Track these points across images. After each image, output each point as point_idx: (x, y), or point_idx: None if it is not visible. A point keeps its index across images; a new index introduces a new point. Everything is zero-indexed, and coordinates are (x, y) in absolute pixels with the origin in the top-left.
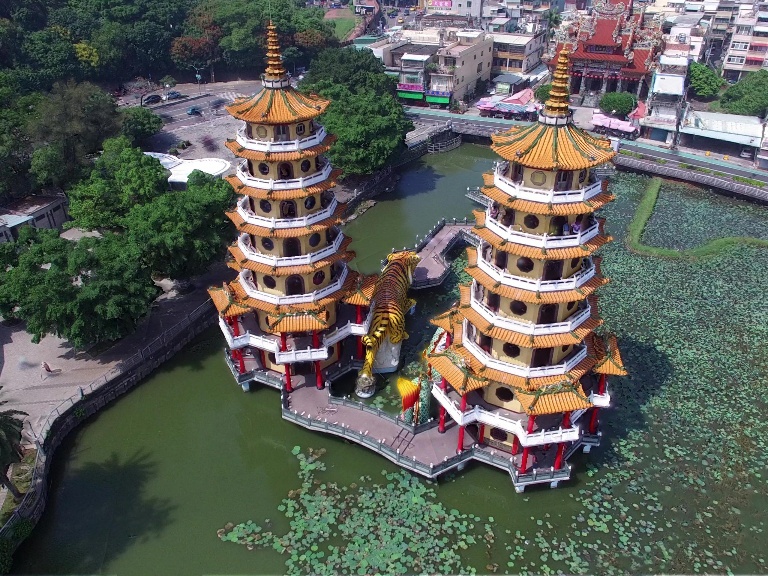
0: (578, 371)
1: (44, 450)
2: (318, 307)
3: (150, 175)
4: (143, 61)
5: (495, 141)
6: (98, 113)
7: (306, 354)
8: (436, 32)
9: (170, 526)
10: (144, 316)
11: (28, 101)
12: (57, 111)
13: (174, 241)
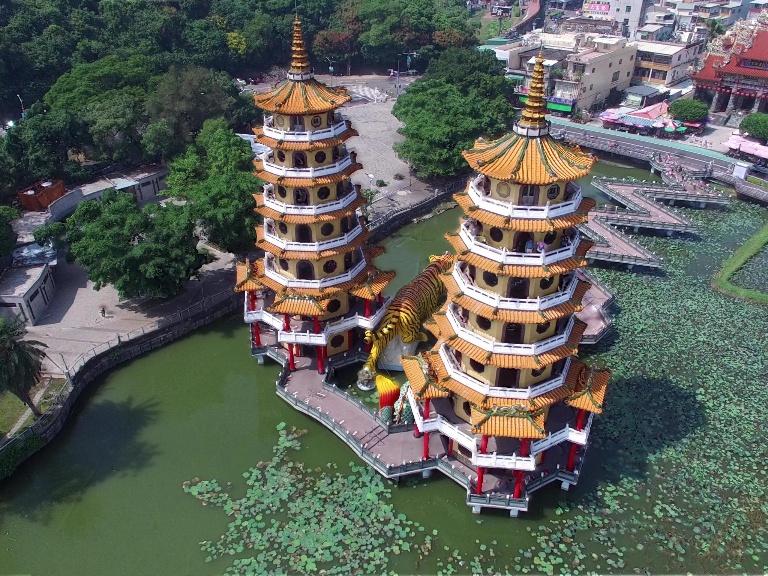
0: (545, 399)
1: (74, 382)
2: (321, 294)
3: (235, 155)
4: (287, 51)
5: (474, 148)
6: (206, 95)
7: (305, 337)
8: (574, 37)
9: (148, 468)
10: (187, 281)
11: (156, 81)
12: (170, 91)
13: (225, 216)
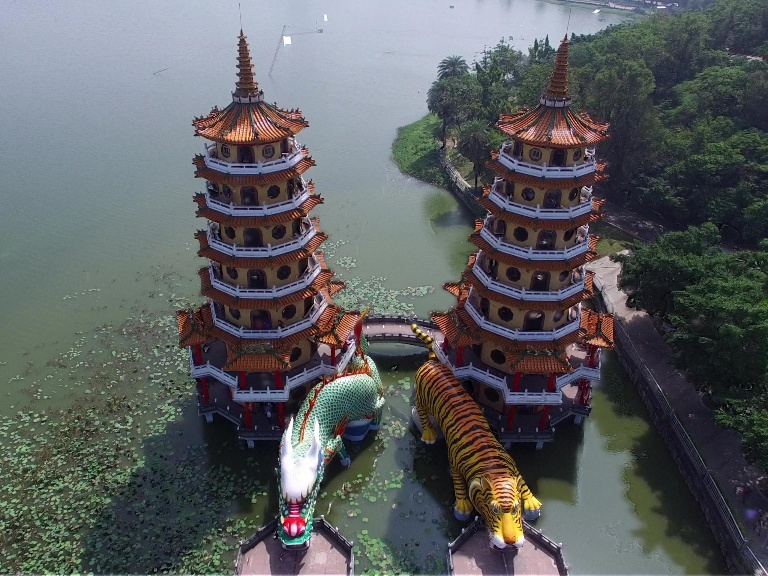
0: None
1: None
2: None
3: None
4: None
5: None
6: None
7: None
8: None
9: None
10: None
11: None
12: None
13: None
